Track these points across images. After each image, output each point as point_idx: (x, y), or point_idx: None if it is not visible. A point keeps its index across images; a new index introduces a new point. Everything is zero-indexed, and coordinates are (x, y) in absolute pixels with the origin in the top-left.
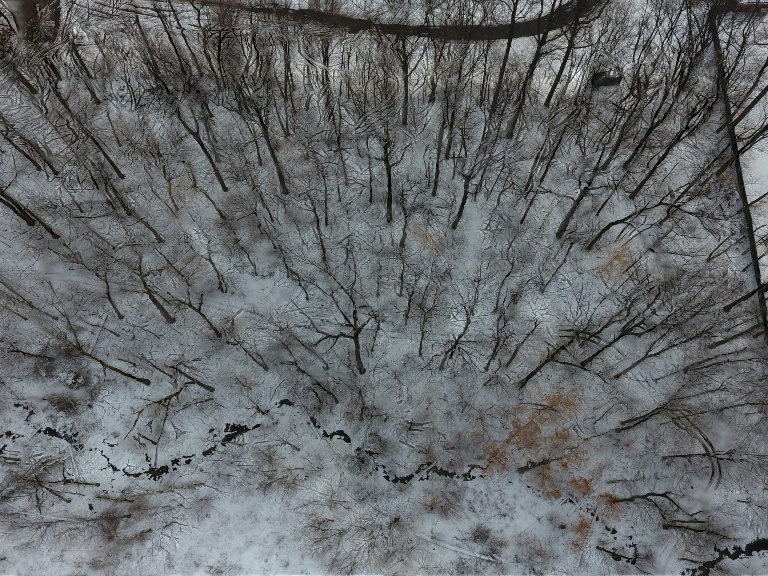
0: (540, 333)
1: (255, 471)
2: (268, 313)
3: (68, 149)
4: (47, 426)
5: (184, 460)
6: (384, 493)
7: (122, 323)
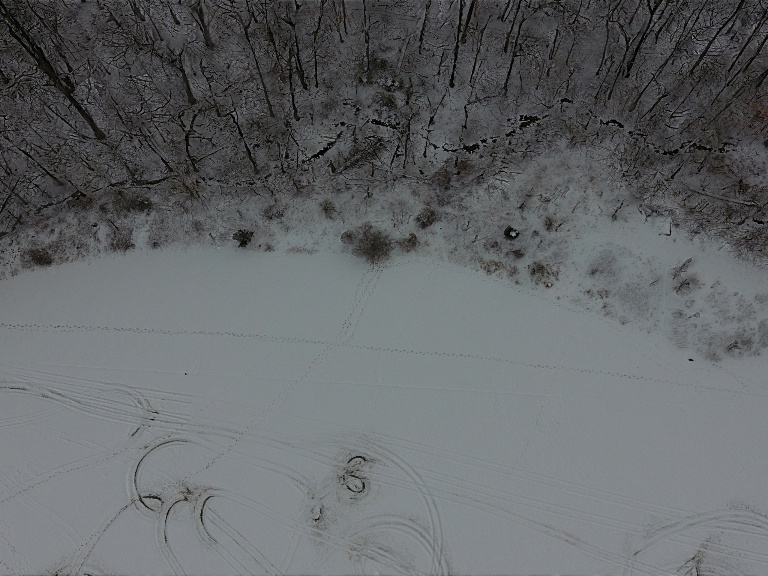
0: (766, 49)
1: (561, 135)
2: (542, 36)
3: None
4: (373, 118)
5: (491, 140)
6: (660, 159)
7: None
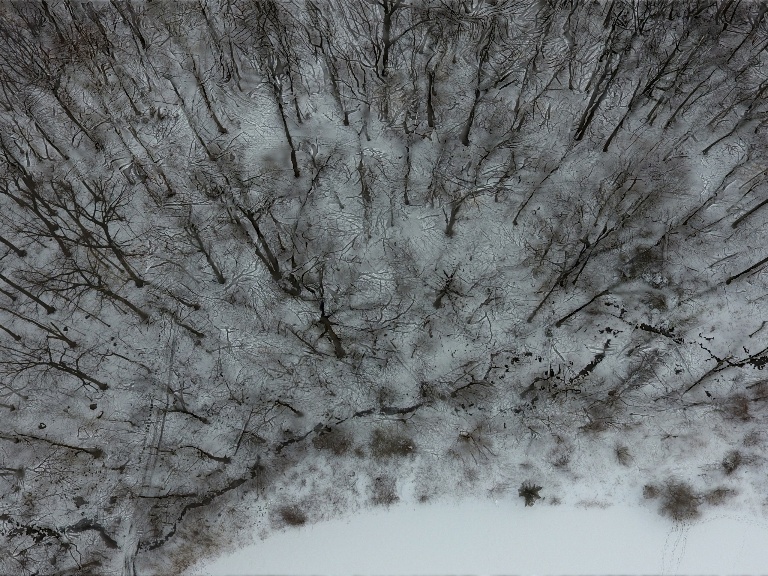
0: None
1: None
2: None
3: (602, 68)
4: (642, 322)
5: None
6: None
7: (689, 228)
